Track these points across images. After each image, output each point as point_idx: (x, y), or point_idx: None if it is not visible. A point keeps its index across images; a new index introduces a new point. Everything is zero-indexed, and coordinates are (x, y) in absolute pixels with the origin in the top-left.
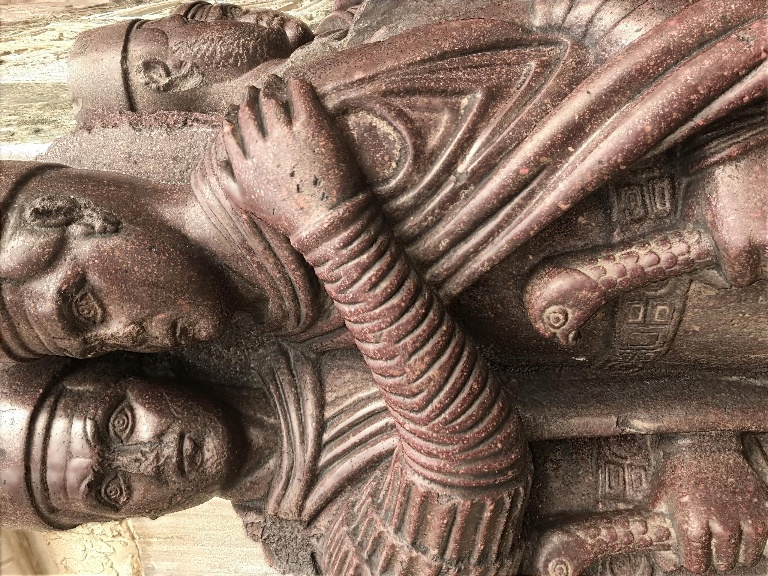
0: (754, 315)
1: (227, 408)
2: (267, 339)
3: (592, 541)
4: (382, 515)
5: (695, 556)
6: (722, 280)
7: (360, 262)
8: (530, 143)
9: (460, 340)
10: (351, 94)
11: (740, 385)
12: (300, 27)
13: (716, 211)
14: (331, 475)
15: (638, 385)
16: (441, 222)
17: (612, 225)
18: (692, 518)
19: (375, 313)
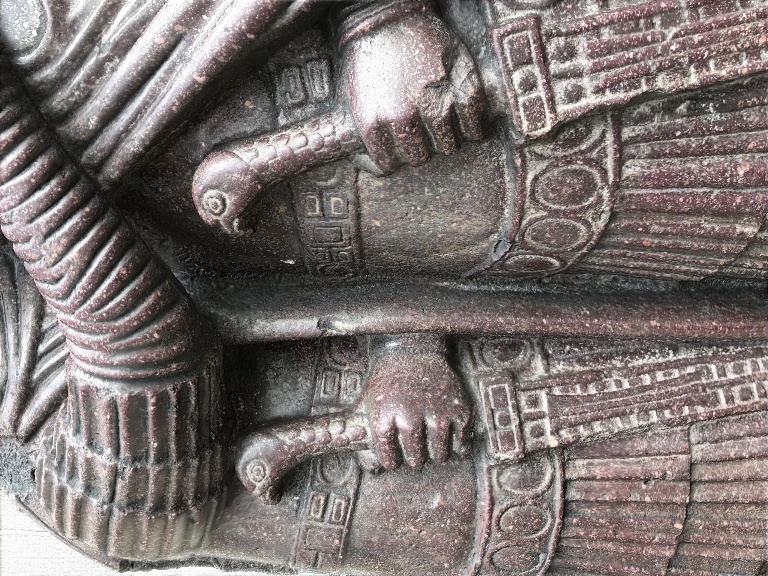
0: (425, 208)
1: None
2: None
3: (290, 442)
4: (66, 419)
5: (384, 452)
6: (374, 165)
7: None
8: (164, 9)
9: (109, 224)
10: None
11: (447, 289)
12: None
13: (352, 88)
14: (45, 387)
15: (348, 289)
16: (90, 98)
17: (276, 109)
18: (381, 415)
19: (2, 189)
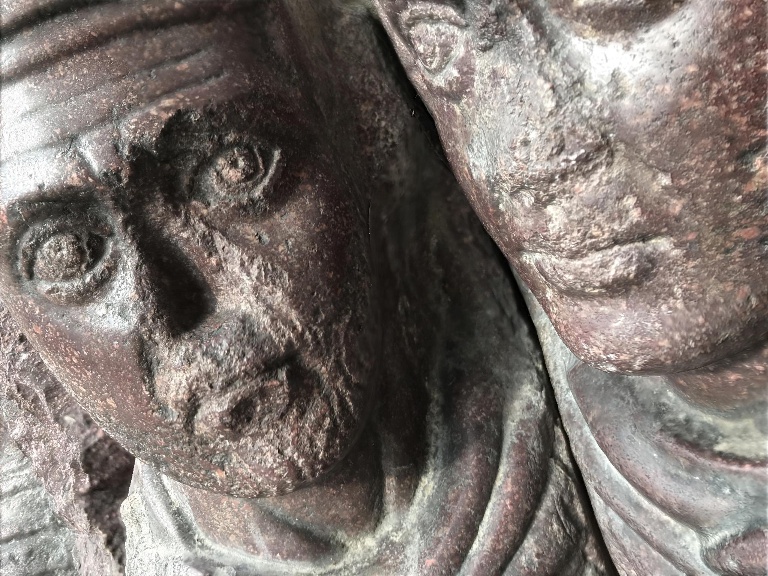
0: None
1: None
2: None
3: None
4: None
5: None
6: None
7: None
8: None
9: None
10: None
11: None
12: (618, 368)
13: None
14: None
15: None
16: None
17: None
18: None
19: None
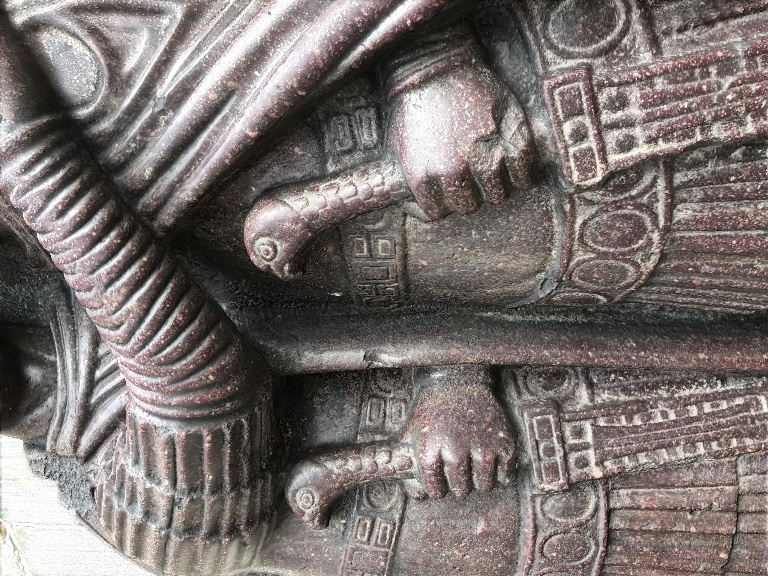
0: (472, 249)
1: (4, 346)
2: (49, 276)
3: (338, 471)
4: (125, 449)
5: (430, 483)
6: (423, 212)
7: (44, 189)
8: (217, 67)
9: (165, 272)
10: (41, 10)
11: (491, 320)
12: None
13: (402, 141)
14: (103, 411)
15: (394, 320)
16: (146, 150)
17: (325, 156)
18: (427, 447)
19: (66, 243)
